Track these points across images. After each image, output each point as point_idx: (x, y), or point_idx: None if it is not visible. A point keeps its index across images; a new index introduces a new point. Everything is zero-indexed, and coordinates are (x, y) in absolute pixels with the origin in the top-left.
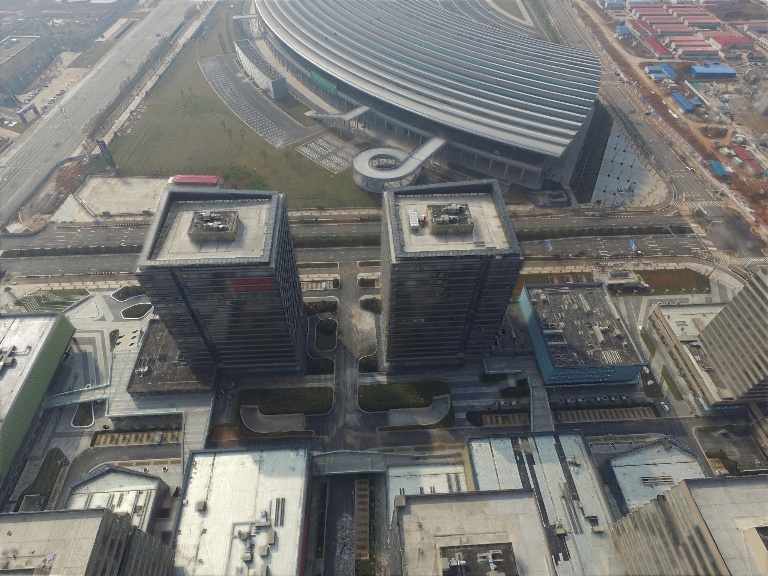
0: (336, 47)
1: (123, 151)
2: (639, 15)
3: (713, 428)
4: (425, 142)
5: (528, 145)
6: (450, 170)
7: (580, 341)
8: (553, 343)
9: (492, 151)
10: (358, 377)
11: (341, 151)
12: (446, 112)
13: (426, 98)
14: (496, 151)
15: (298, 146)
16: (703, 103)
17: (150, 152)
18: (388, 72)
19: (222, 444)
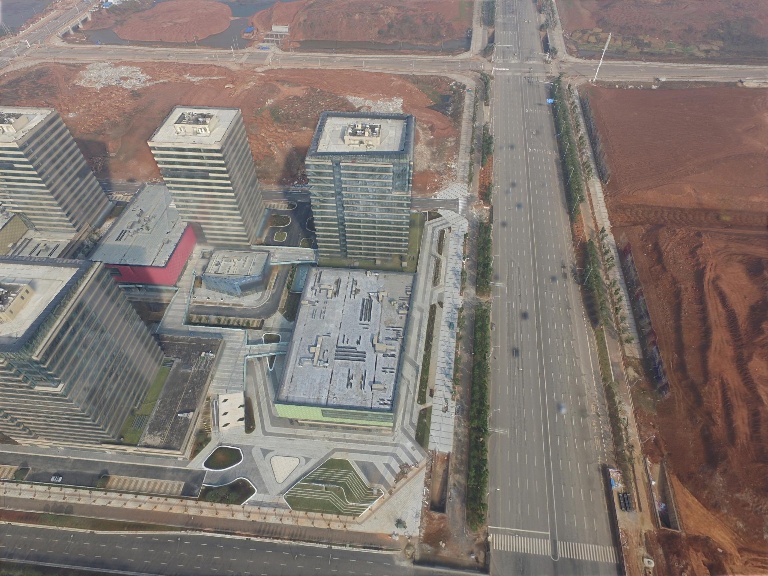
0: None
1: None
2: None
3: None
4: None
5: None
6: None
7: None
8: None
9: None
10: None
11: None
12: None
13: None
14: None
15: None
16: None
17: None
18: None
19: None
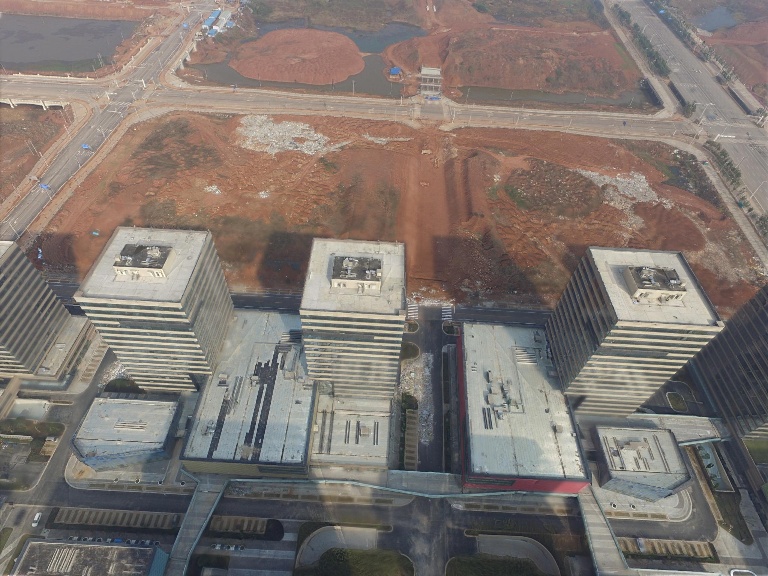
0: None
1: None
2: None
3: (9, 486)
4: None
5: None
6: None
7: None
8: None
9: None
10: None
11: None
12: None
13: None
14: None
15: None
16: None
17: None
18: None
19: (565, 530)
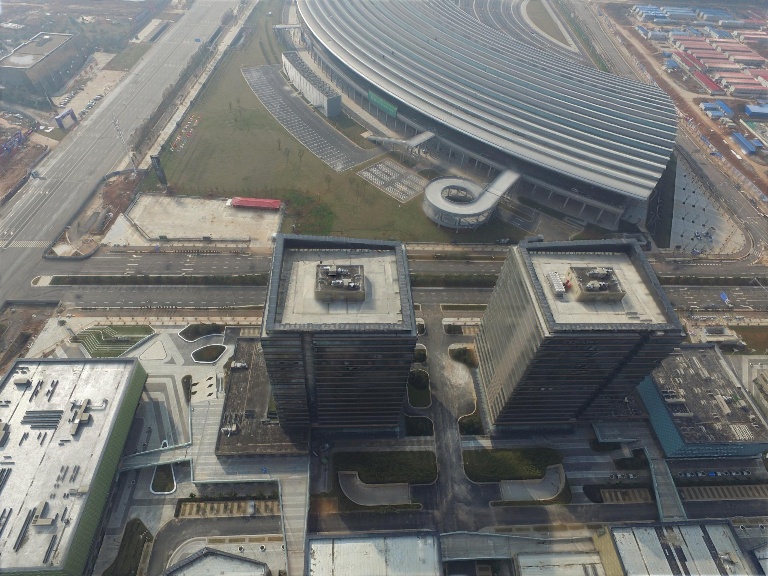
0: (395, 67)
1: (173, 167)
2: (684, 48)
3: None
4: (499, 175)
5: (612, 186)
6: (522, 205)
7: (704, 412)
8: (678, 414)
9: (570, 189)
10: (460, 440)
11: (405, 178)
12: (521, 145)
13: (498, 128)
14: (574, 189)
15: (359, 170)
16: (762, 144)
17: (202, 169)
18: (454, 97)
19: (323, 518)
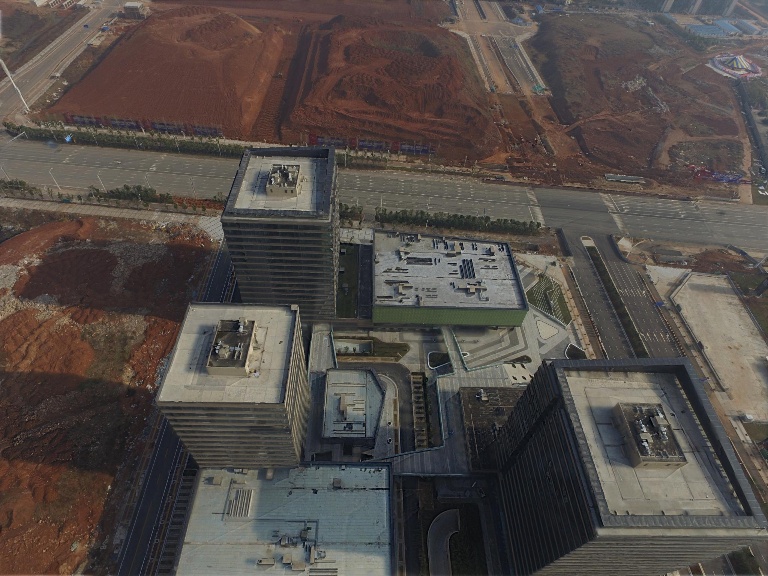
0: None
1: None
2: None
3: None
4: None
5: None
6: None
7: None
8: None
9: None
10: None
11: None
12: None
13: None
14: None
15: None
16: None
17: None
18: None
19: (415, 494)
